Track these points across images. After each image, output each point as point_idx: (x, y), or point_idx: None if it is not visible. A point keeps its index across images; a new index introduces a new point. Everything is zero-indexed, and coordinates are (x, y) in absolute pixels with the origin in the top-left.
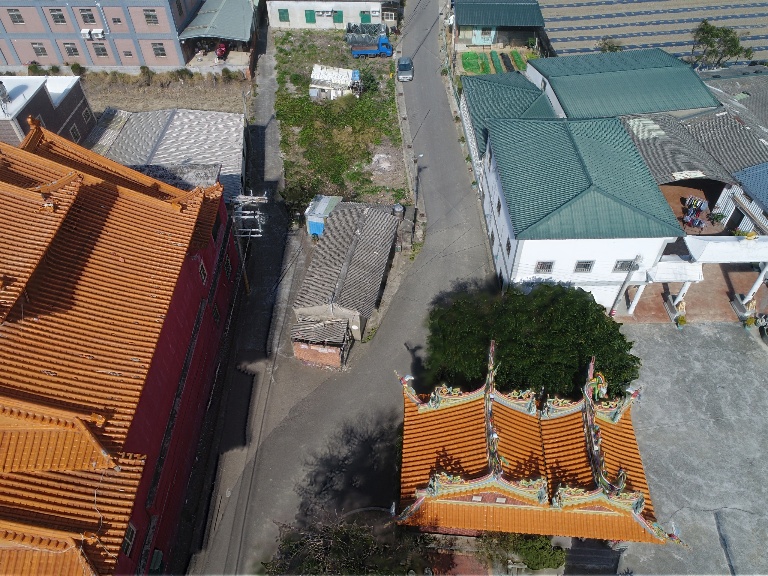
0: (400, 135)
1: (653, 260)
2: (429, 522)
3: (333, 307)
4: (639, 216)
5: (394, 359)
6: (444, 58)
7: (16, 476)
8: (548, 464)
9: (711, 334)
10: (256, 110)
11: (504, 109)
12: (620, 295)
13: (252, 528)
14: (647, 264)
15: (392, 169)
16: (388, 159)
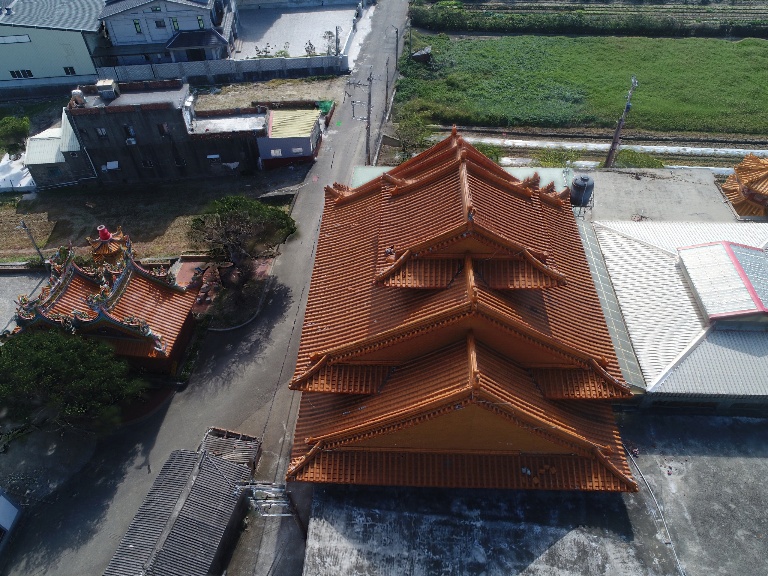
0: None
1: None
2: None
3: None
4: None
5: (167, 454)
6: None
7: None
8: None
9: None
10: None
11: None
12: None
13: None
14: None
15: None
16: None
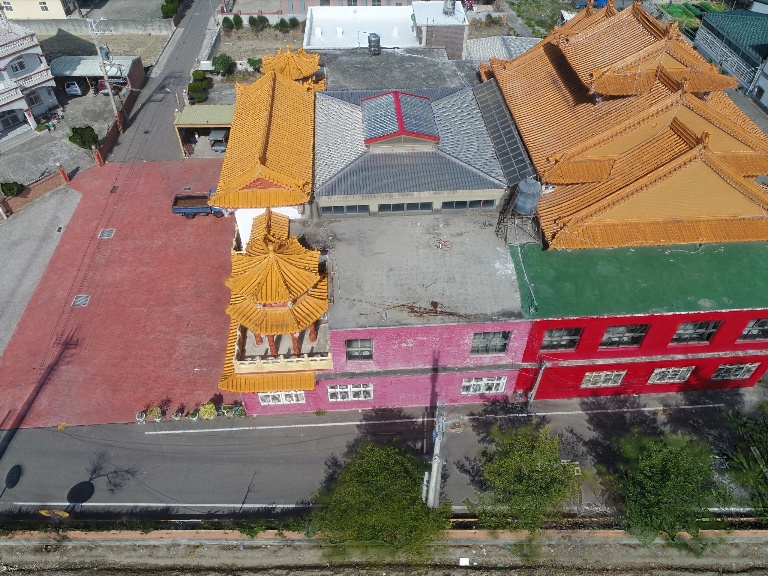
0: None
1: None
2: None
3: None
4: None
5: None
6: (649, 8)
7: None
8: None
9: None
10: None
11: (760, 32)
12: None
13: None
14: None
15: None
16: None
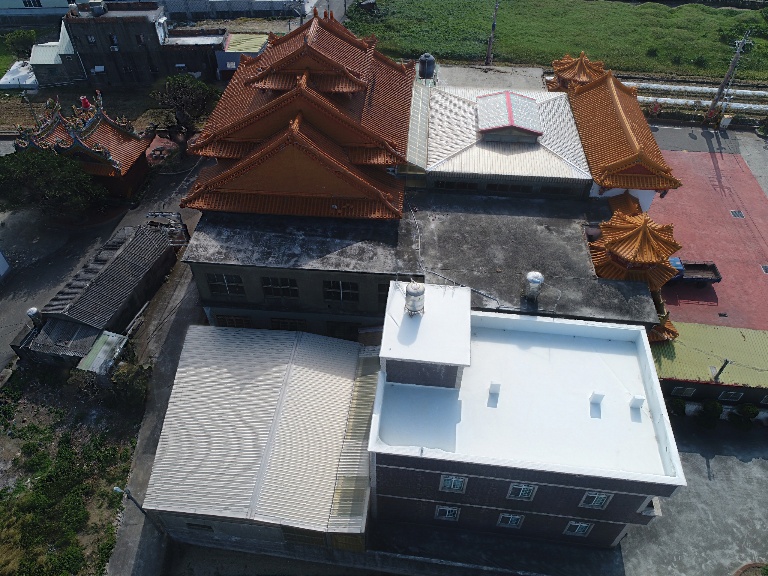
0: None
1: None
2: None
3: None
4: None
5: None
6: None
7: None
8: None
9: None
10: None
11: None
12: None
13: None
14: None
15: None
16: None
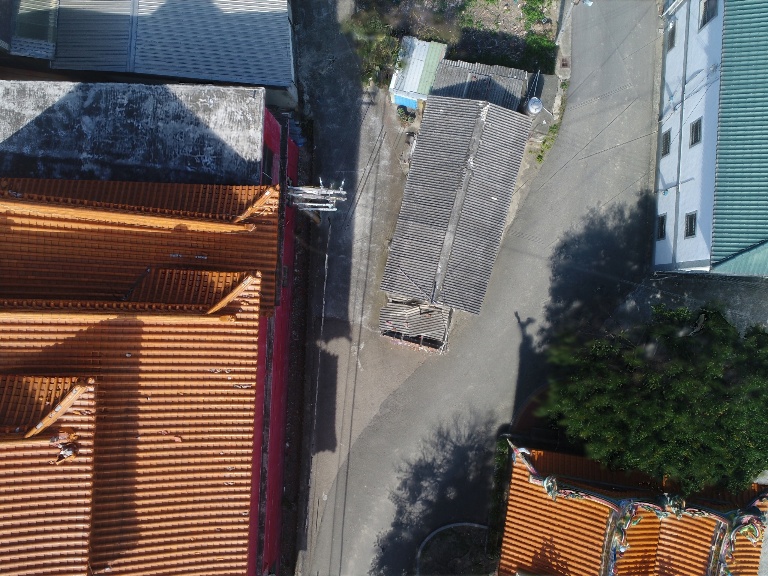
0: None
1: None
2: None
3: None
4: None
5: (501, 336)
6: None
7: None
8: (659, 556)
9: None
10: None
11: None
12: None
13: (351, 533)
14: None
15: None
16: None
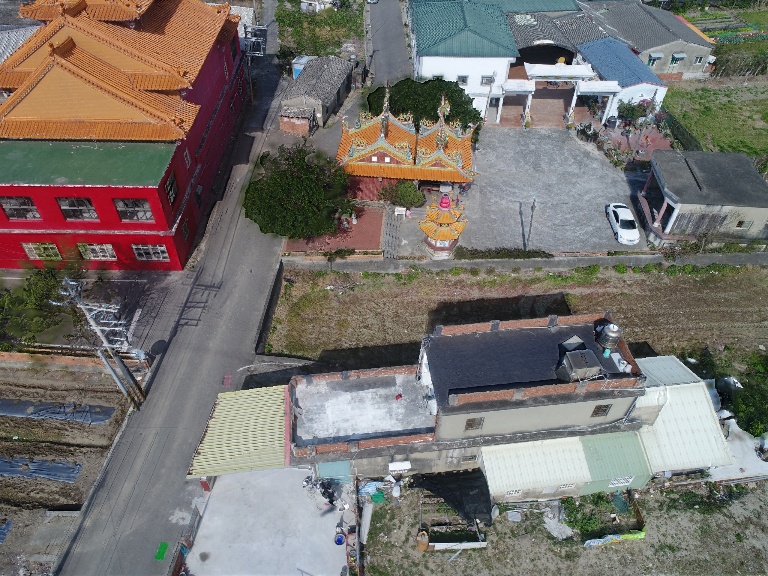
0: (364, 33)
1: (504, 76)
2: (348, 172)
3: (305, 98)
4: (493, 45)
5: None
6: None
7: (141, 93)
8: None
9: (546, 133)
10: (261, 17)
11: None
12: (487, 104)
13: None
14: (501, 80)
15: (355, 51)
16: (353, 46)
